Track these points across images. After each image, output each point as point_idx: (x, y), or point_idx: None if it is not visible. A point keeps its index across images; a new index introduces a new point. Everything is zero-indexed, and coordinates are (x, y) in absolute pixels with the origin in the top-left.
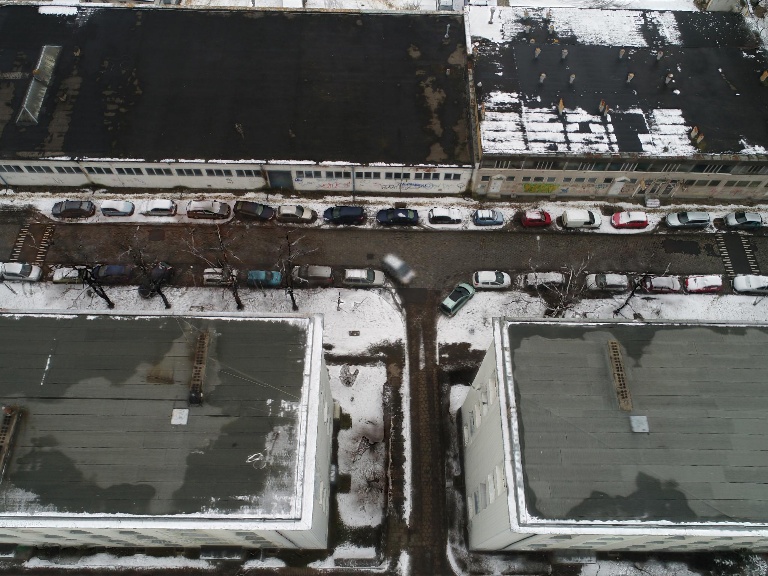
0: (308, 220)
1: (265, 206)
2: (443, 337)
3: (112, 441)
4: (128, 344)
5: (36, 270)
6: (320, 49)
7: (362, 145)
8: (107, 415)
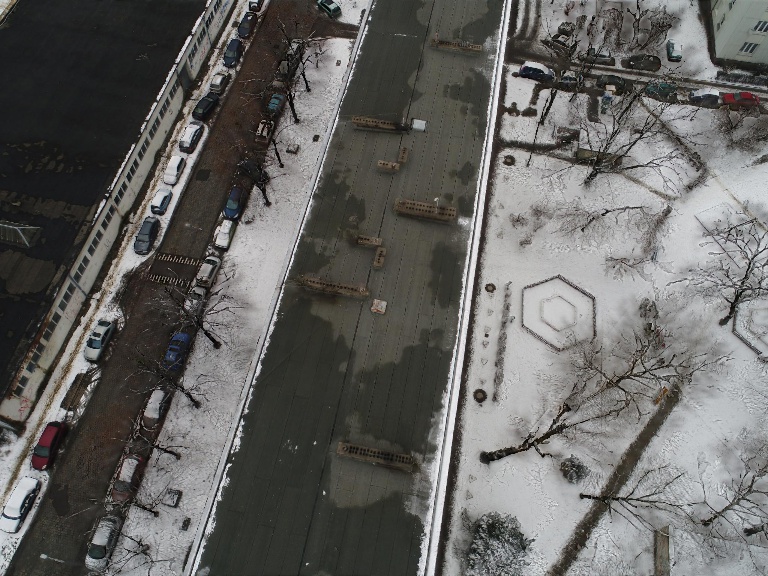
0: (229, 76)
1: (205, 96)
2: (354, 21)
3: (461, 6)
4: (395, 1)
5: (211, 258)
6: (62, 13)
7: (185, 7)
8: (444, 8)
